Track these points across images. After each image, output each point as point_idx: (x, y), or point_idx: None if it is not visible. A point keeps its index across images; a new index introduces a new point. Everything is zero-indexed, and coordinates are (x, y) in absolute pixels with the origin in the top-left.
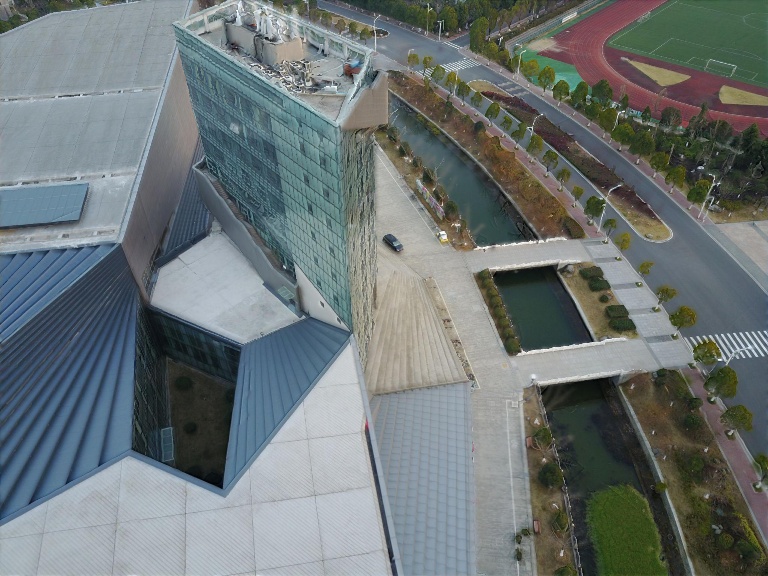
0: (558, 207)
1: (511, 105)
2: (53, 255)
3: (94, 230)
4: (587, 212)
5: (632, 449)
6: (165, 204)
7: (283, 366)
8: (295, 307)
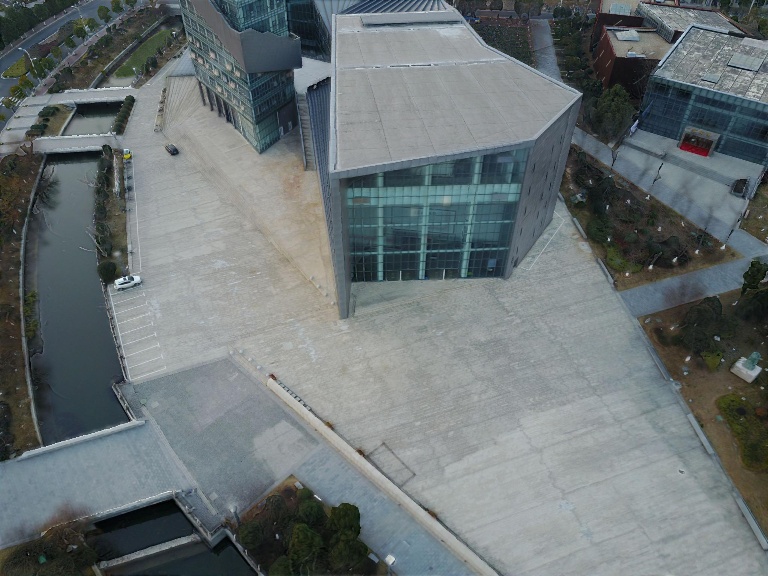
0: (0, 176)
1: None
2: None
3: (351, 17)
4: None
5: None
6: None
7: None
8: None
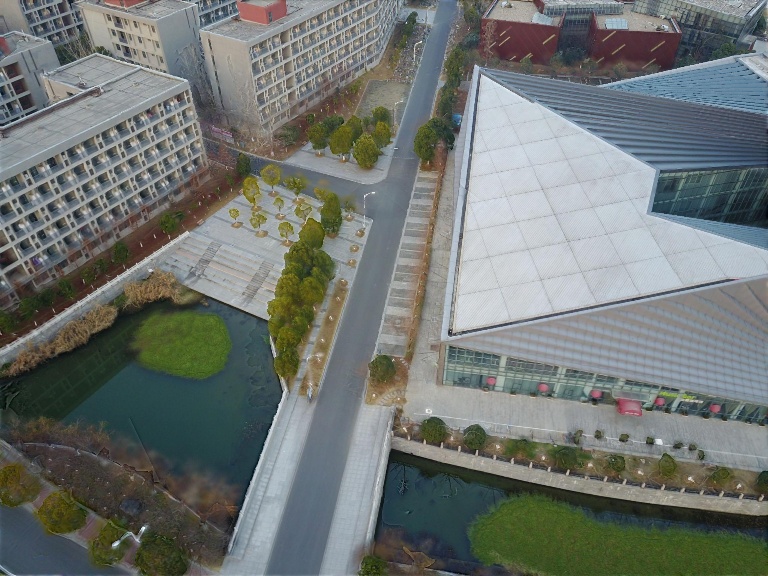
0: None
1: None
2: None
3: None
4: None
5: None
6: None
7: None
8: None
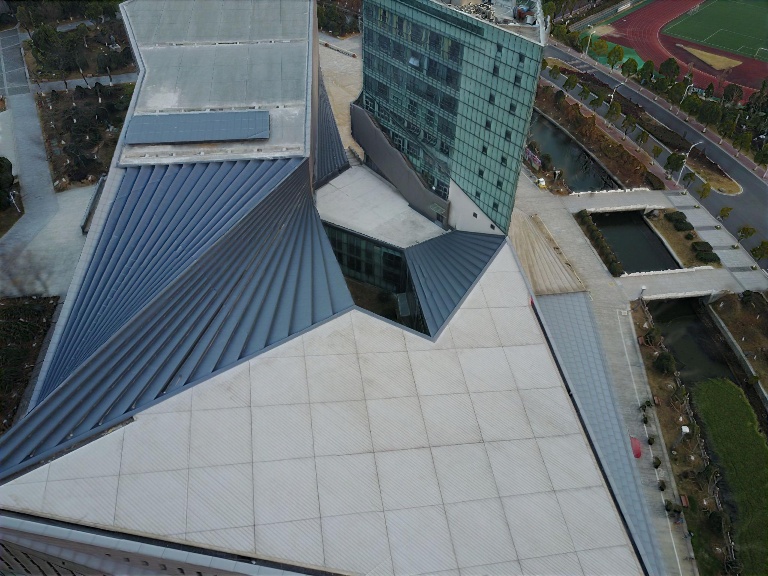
0: (639, 164)
1: (583, 80)
2: (253, 164)
3: (283, 147)
4: (667, 167)
5: (725, 352)
6: (314, 139)
7: (449, 261)
8: (442, 222)
